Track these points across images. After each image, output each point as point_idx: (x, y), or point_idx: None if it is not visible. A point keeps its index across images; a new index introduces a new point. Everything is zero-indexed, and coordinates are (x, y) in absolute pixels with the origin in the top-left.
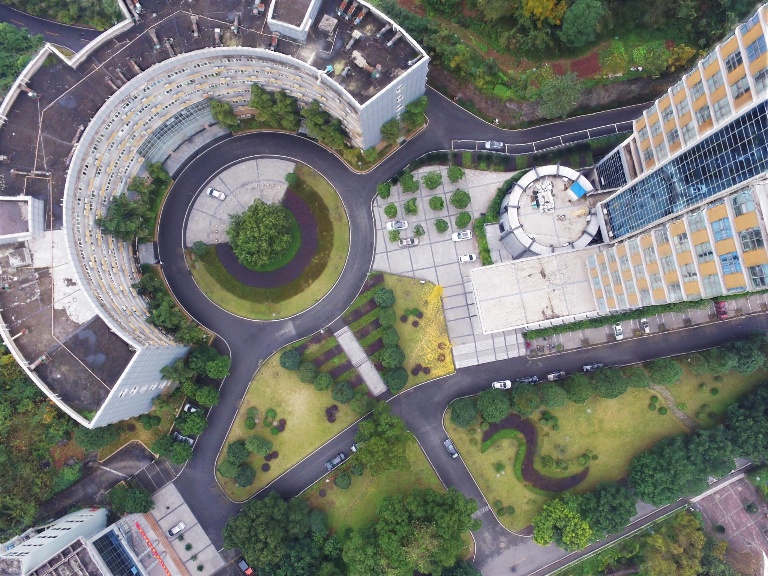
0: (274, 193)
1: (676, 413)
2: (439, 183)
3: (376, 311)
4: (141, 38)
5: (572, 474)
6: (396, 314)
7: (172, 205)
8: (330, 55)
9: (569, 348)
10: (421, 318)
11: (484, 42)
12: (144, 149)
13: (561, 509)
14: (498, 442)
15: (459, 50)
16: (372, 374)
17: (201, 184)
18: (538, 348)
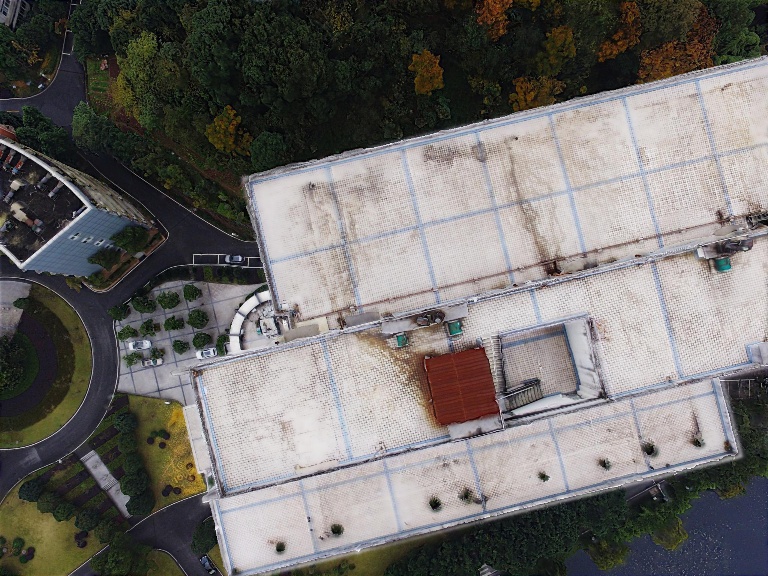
0: (10, 317)
1: None
2: (177, 302)
3: (121, 435)
4: None
5: None
6: (143, 436)
7: None
8: None
9: None
10: (168, 439)
11: (203, 159)
12: None
13: None
14: None
15: (169, 173)
16: (123, 496)
17: None
18: None
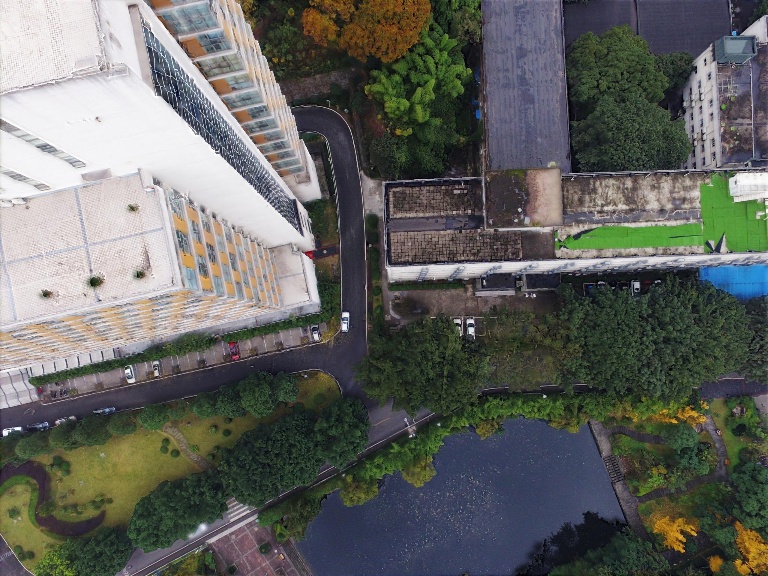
0: None
1: (190, 455)
2: None
3: None
4: None
5: (88, 518)
6: None
7: None
8: None
9: (83, 392)
10: None
11: None
12: None
13: (51, 556)
14: (12, 488)
15: None
16: None
17: None
18: (50, 394)
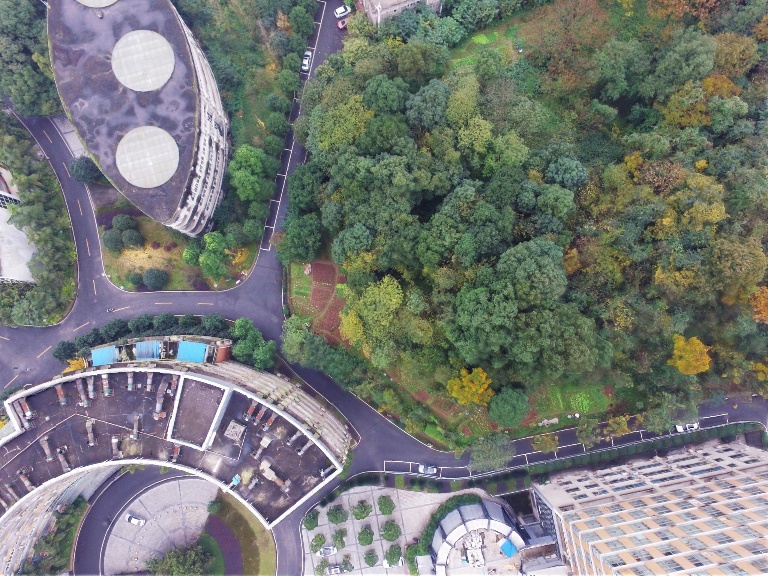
0: (197, 516)
1: None
2: (369, 512)
3: None
4: (33, 446)
5: None
6: None
7: (89, 531)
8: (237, 461)
9: None
10: None
11: None
12: (51, 505)
13: None
14: None
15: (386, 400)
16: None
17: (120, 508)
18: None
